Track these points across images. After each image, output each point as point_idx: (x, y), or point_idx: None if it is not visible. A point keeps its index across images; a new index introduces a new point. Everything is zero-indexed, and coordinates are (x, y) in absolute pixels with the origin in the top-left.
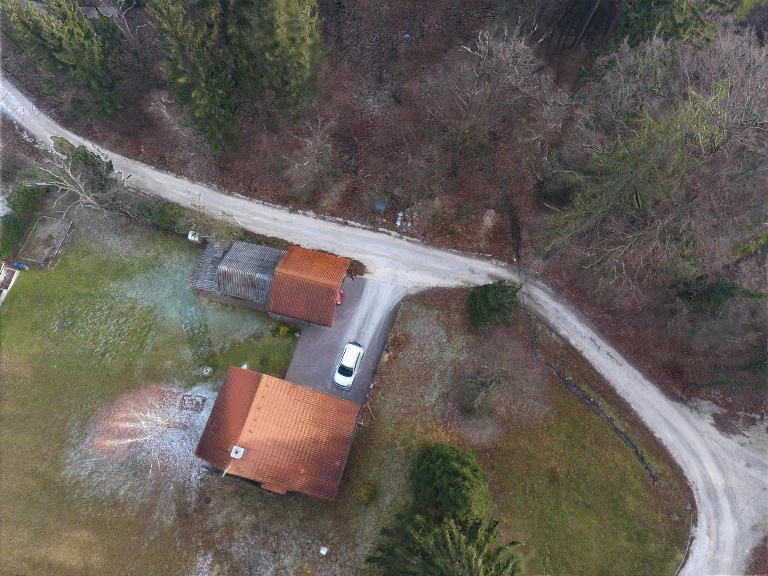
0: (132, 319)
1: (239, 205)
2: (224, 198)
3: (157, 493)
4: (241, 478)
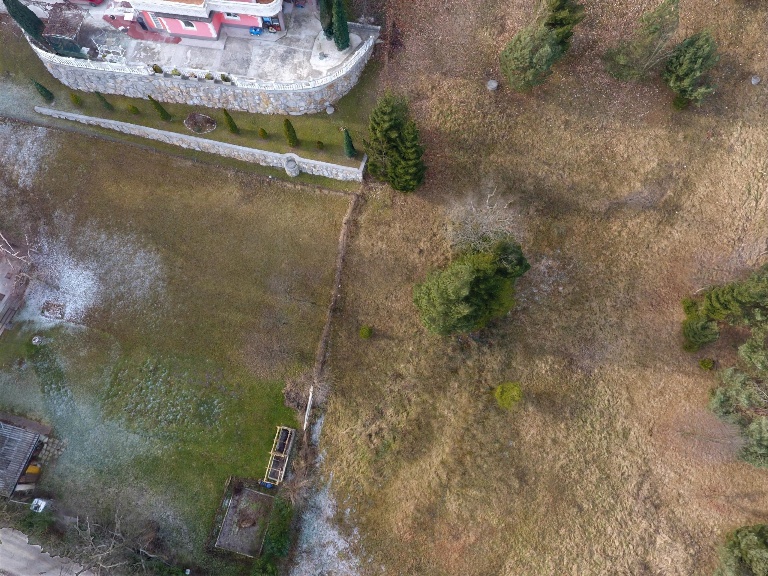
0: (129, 407)
1: (4, 559)
2: (24, 573)
3: (73, 234)
4: (1, 241)
